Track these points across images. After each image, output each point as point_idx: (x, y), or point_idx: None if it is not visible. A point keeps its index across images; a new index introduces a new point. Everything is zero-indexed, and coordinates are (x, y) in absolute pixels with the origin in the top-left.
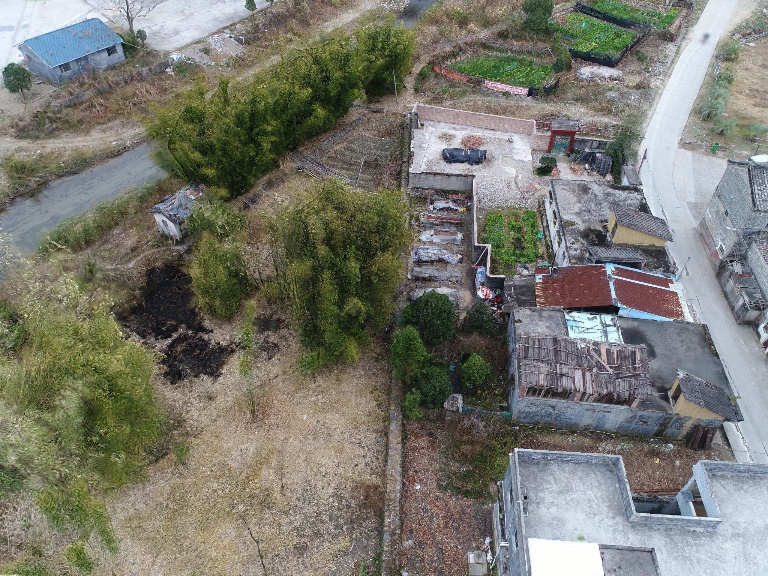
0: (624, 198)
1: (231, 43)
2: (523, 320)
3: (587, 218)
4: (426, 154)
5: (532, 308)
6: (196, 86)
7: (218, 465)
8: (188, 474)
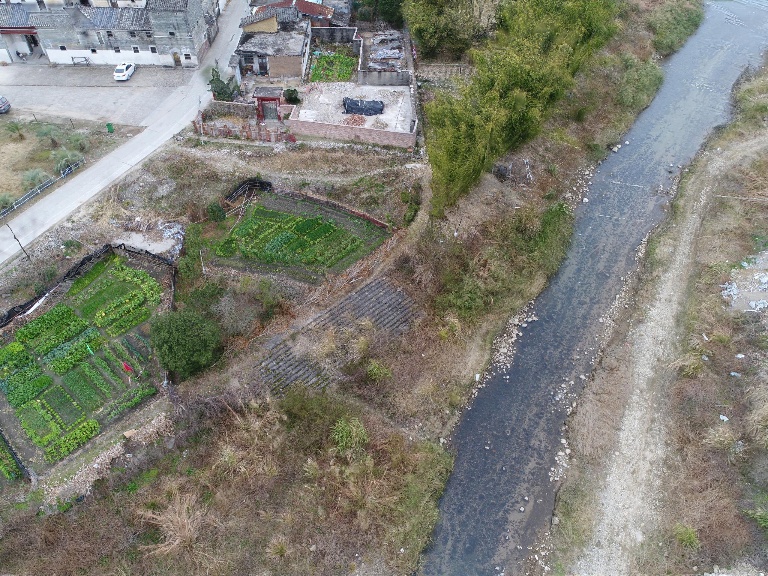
0: (253, 46)
1: (759, 297)
2: (343, 3)
3: (287, 36)
4: (399, 109)
5: (337, 6)
6: (723, 225)
7: (474, 7)
8: (484, 5)
